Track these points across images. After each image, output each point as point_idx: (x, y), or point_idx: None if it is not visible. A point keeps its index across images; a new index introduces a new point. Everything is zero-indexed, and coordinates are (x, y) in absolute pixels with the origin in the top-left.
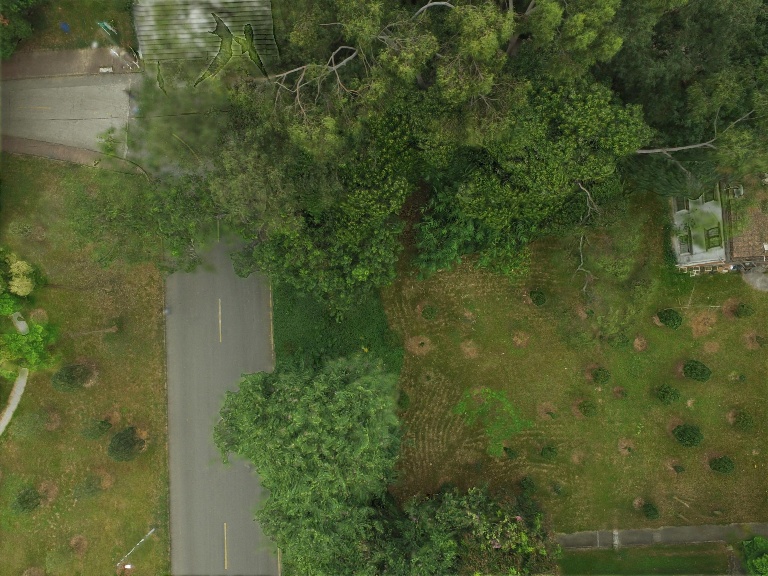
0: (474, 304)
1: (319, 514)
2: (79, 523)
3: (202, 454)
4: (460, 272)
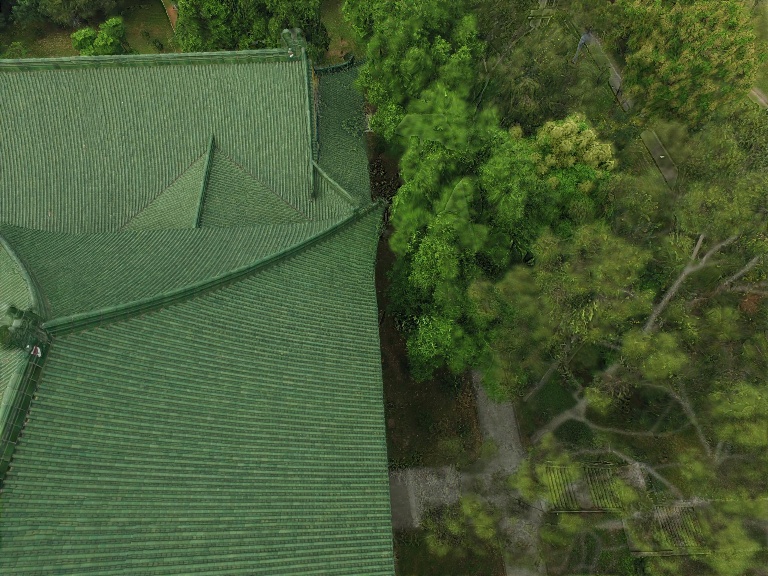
0: (56, 52)
1: None
2: None
3: None
4: (55, 42)
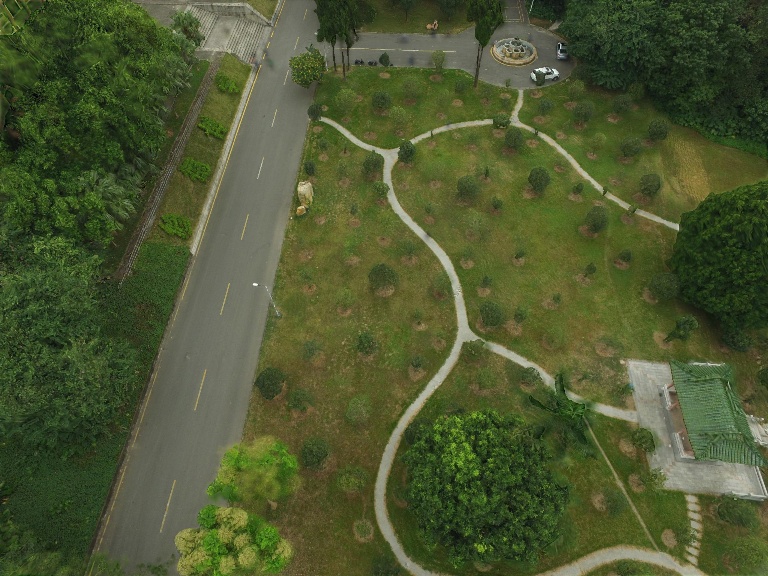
0: None
1: (1, 296)
2: (342, 325)
3: (225, 371)
4: None
